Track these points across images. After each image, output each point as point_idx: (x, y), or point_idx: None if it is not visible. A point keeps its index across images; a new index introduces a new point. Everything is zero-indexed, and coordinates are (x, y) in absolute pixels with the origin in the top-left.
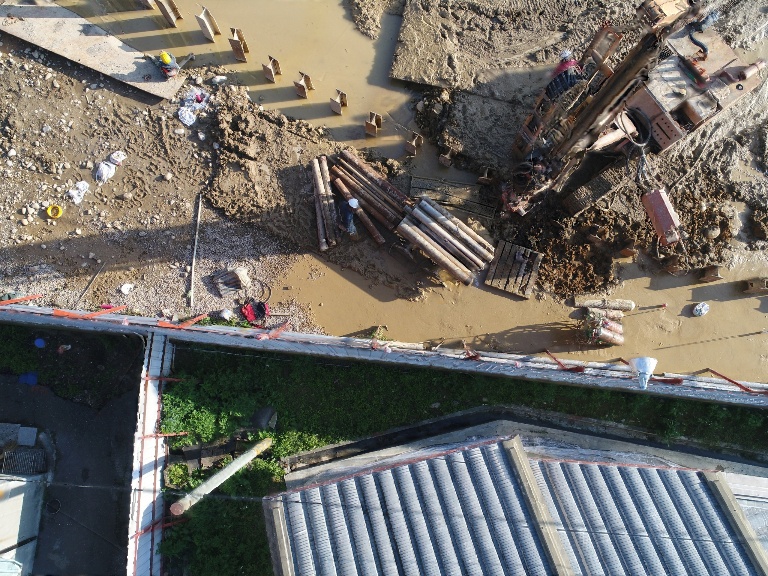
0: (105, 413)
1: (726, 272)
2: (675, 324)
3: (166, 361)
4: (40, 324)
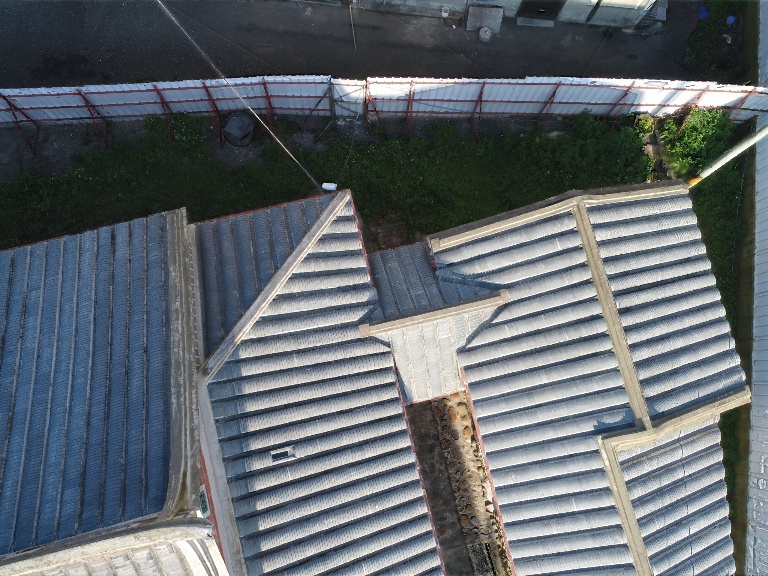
0: (680, 70)
1: None
2: None
3: (745, 112)
4: (759, 17)
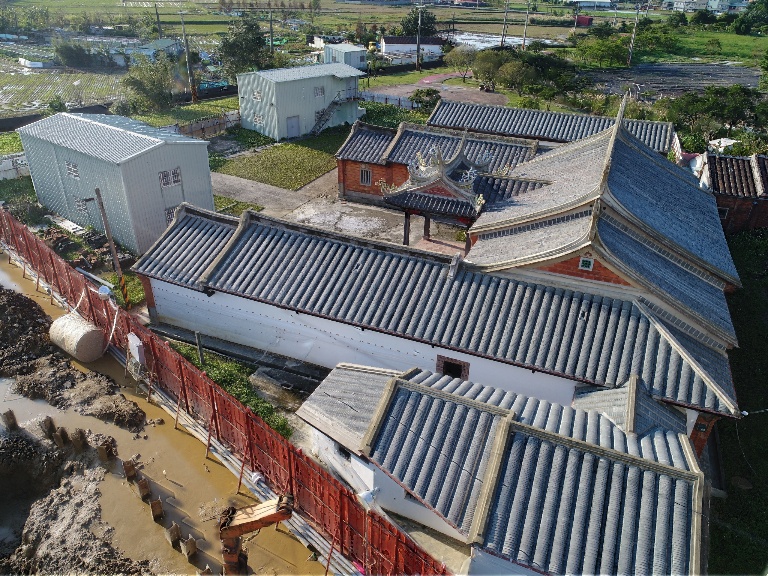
0: None
1: (191, 575)
2: (264, 571)
3: None
4: None
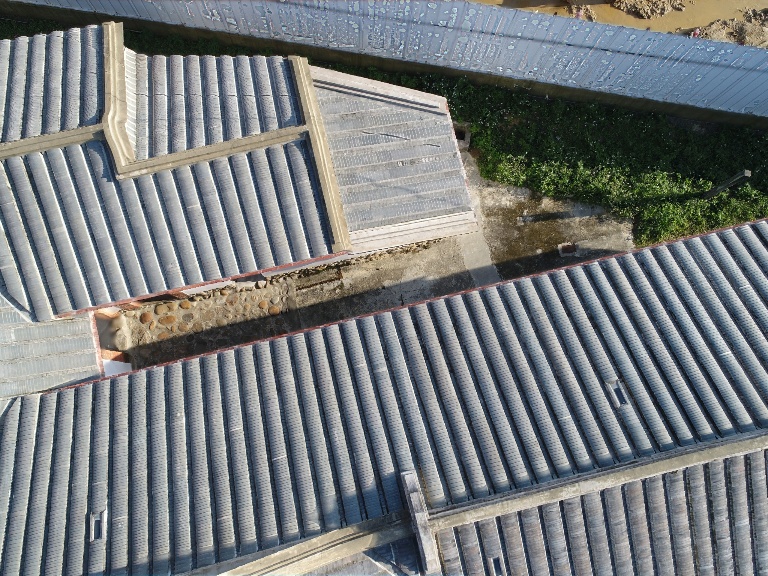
0: None
1: None
2: None
3: None
4: None
